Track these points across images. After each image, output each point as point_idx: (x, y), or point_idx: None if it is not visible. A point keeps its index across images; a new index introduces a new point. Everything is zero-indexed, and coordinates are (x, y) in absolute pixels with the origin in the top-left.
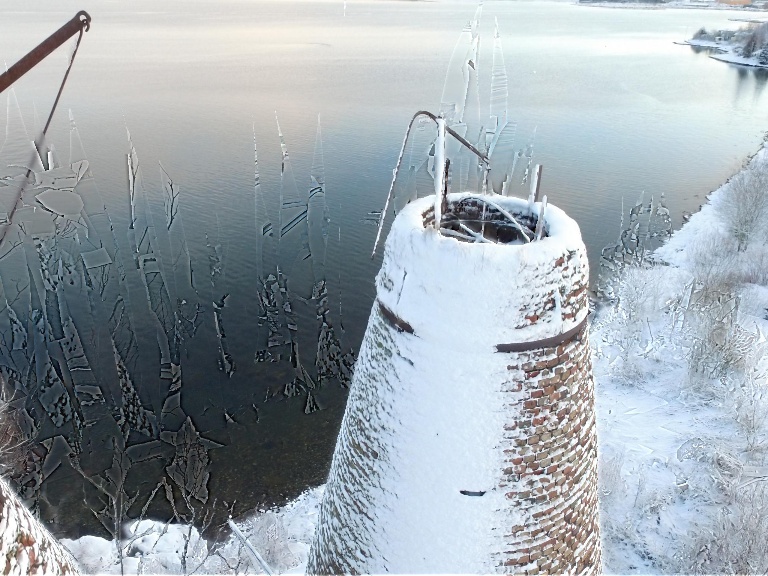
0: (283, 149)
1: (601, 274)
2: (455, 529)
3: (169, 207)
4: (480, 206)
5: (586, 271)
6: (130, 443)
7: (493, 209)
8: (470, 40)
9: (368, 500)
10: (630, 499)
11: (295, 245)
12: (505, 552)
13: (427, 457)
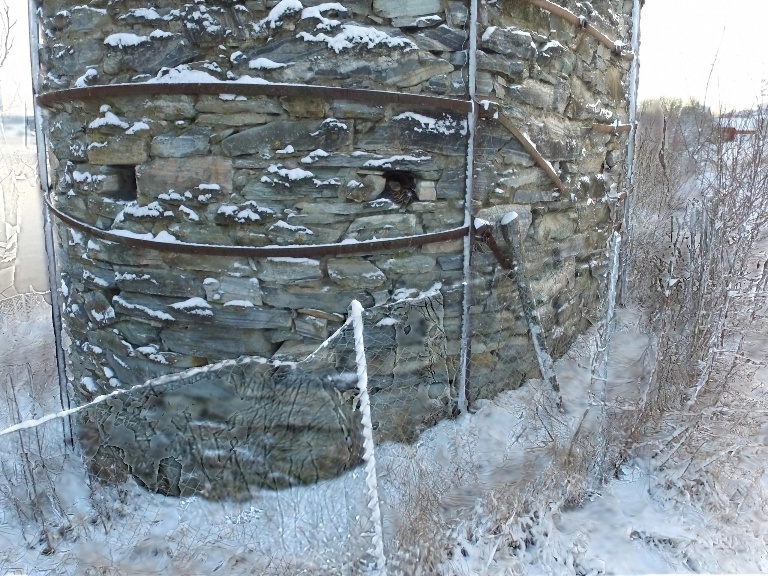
0: None
1: None
2: None
3: (3, 38)
4: None
5: None
6: None
7: None
8: None
9: None
10: None
11: None
12: None
13: None
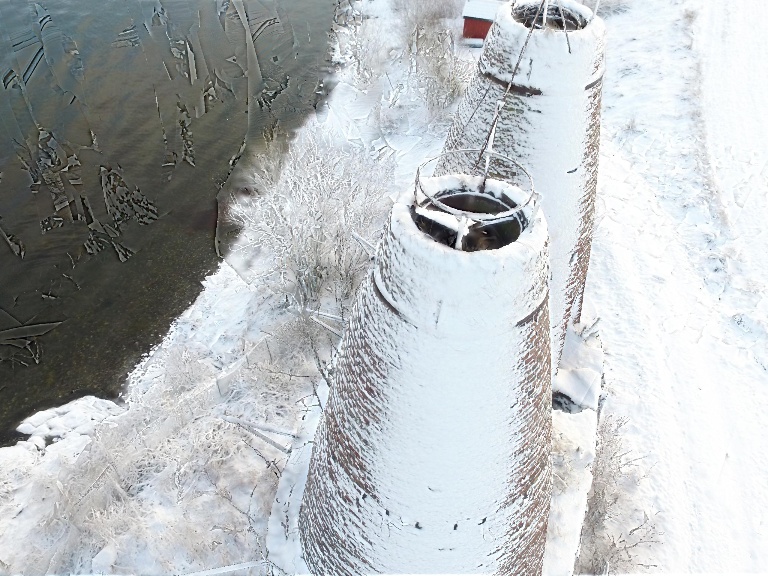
0: None
1: (340, 41)
2: (566, 193)
3: None
4: None
5: None
6: None
7: (532, 8)
8: None
9: None
10: None
11: (44, 91)
12: (583, 197)
13: (553, 160)
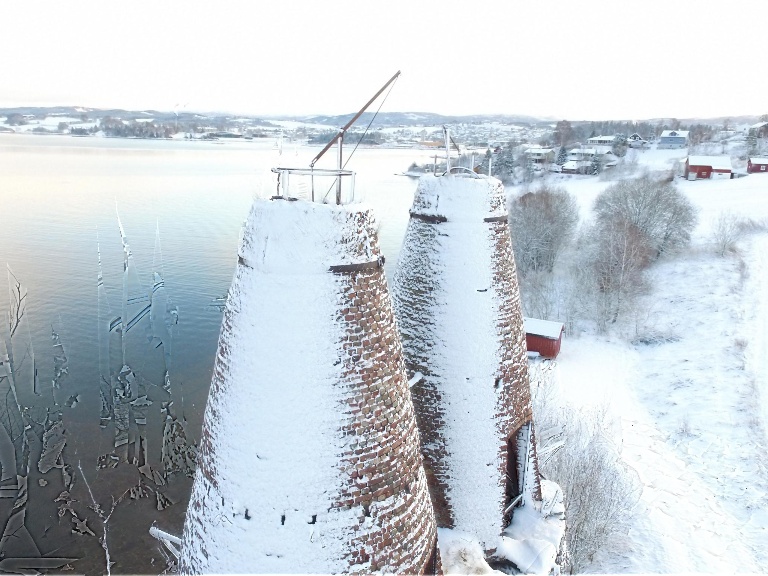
0: (127, 249)
1: None
2: (478, 309)
3: (15, 310)
4: None
5: None
6: None
7: None
8: (278, 156)
9: (430, 315)
10: None
11: (140, 339)
12: (498, 319)
13: (461, 276)
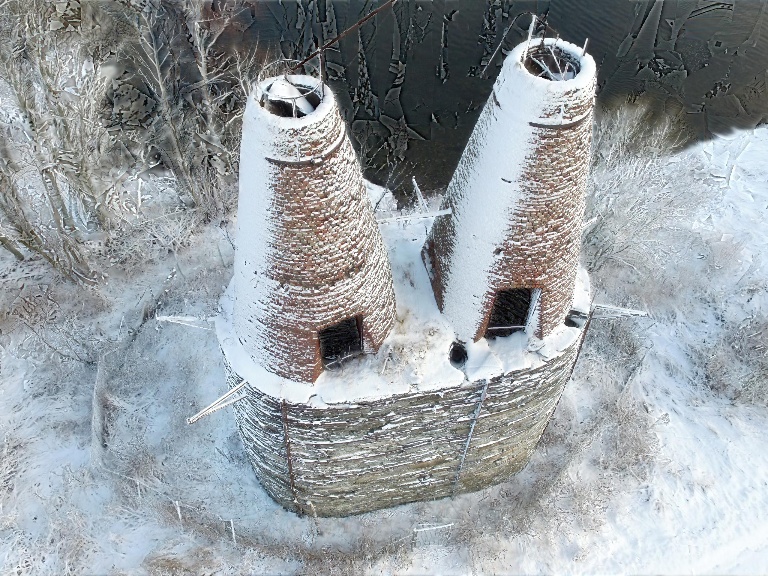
0: None
1: None
2: (496, 193)
3: None
4: (561, 50)
5: (587, 99)
6: (358, 117)
7: (566, 53)
8: None
9: (468, 174)
10: (737, 278)
11: None
12: (514, 209)
13: (492, 161)
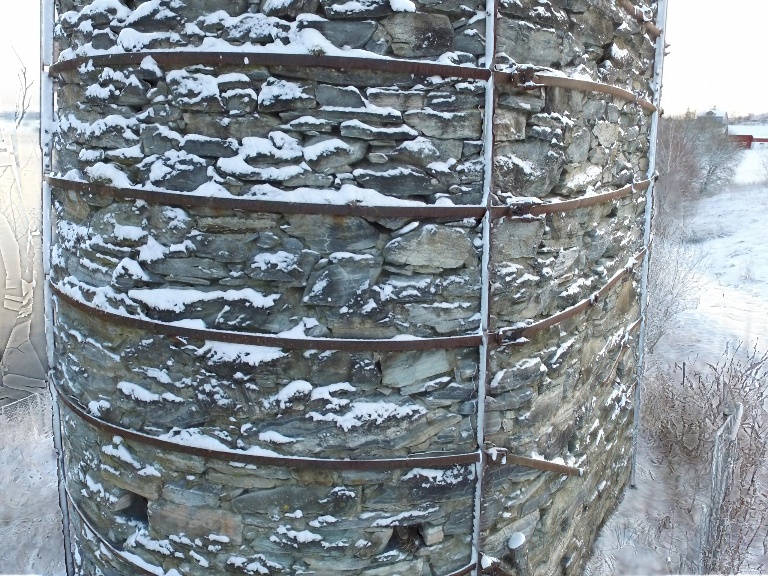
0: None
1: None
2: None
3: (21, 98)
4: None
5: None
6: None
7: None
8: None
9: None
10: None
11: None
12: None
13: None
